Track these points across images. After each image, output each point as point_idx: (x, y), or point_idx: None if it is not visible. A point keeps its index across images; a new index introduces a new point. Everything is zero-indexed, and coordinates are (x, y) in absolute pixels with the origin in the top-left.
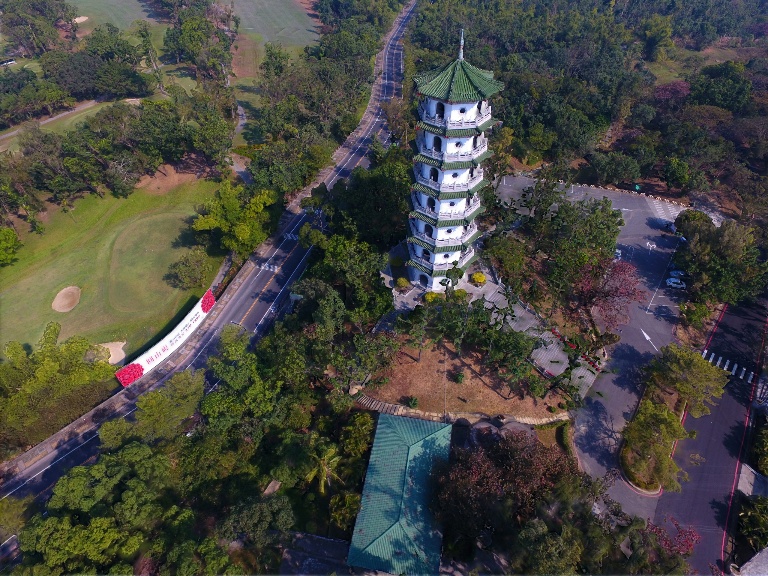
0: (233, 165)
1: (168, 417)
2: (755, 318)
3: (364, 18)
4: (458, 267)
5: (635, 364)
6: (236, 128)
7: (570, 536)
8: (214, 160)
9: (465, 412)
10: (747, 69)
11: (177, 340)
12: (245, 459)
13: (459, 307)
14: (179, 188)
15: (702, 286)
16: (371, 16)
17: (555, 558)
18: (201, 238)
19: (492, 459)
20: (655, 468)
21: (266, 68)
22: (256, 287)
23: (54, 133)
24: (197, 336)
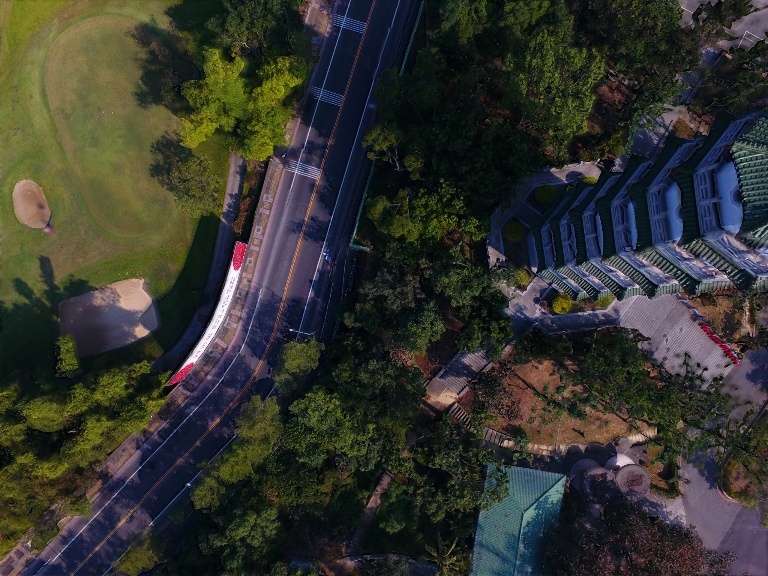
0: None
1: None
2: None
3: None
4: None
5: None
6: None
7: None
8: None
9: (578, 444)
10: None
11: (219, 320)
12: None
13: None
14: None
15: None
16: None
17: None
18: (187, 116)
19: (613, 546)
20: (761, 502)
21: None
22: (295, 211)
23: None
24: (238, 300)
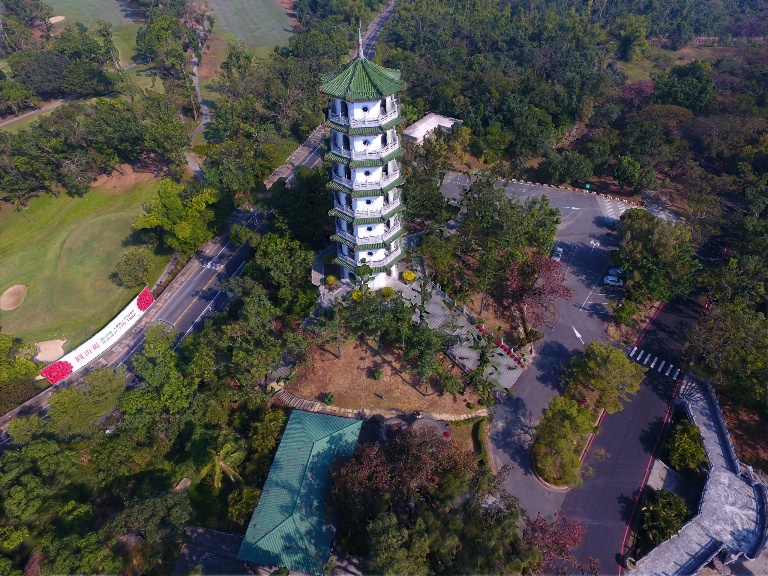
0: (188, 164)
1: (85, 414)
2: (690, 315)
3: (341, 18)
4: (382, 265)
5: (562, 361)
6: (198, 127)
7: (423, 528)
8: None
9: (381, 408)
10: (715, 68)
11: (110, 338)
12: (160, 455)
13: None
14: (135, 187)
15: (634, 284)
16: (348, 16)
17: (393, 549)
18: (147, 237)
19: (390, 454)
20: (561, 463)
21: (226, 67)
22: (197, 285)
23: (6, 132)
24: (132, 334)
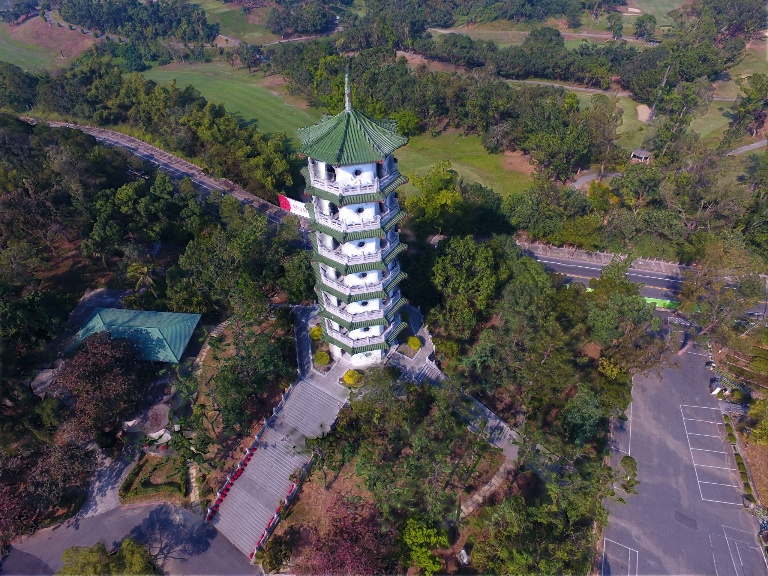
0: None
1: None
2: None
3: None
4: (327, 331)
5: None
6: None
7: None
8: (569, 177)
9: (200, 383)
10: None
11: None
12: None
13: (284, 345)
14: (518, 174)
15: None
16: None
17: None
18: None
19: None
20: None
21: (725, 136)
22: None
23: None
24: None
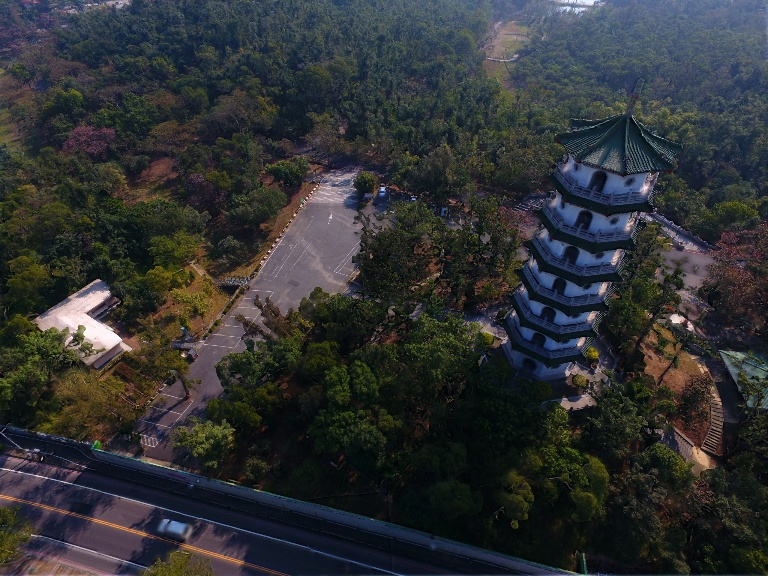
0: None
1: None
2: None
3: None
4: None
5: None
6: None
7: None
8: None
9: None
10: None
11: None
12: None
13: None
14: None
15: None
16: None
17: None
18: None
19: (759, 313)
20: None
21: None
22: None
23: None
24: None
